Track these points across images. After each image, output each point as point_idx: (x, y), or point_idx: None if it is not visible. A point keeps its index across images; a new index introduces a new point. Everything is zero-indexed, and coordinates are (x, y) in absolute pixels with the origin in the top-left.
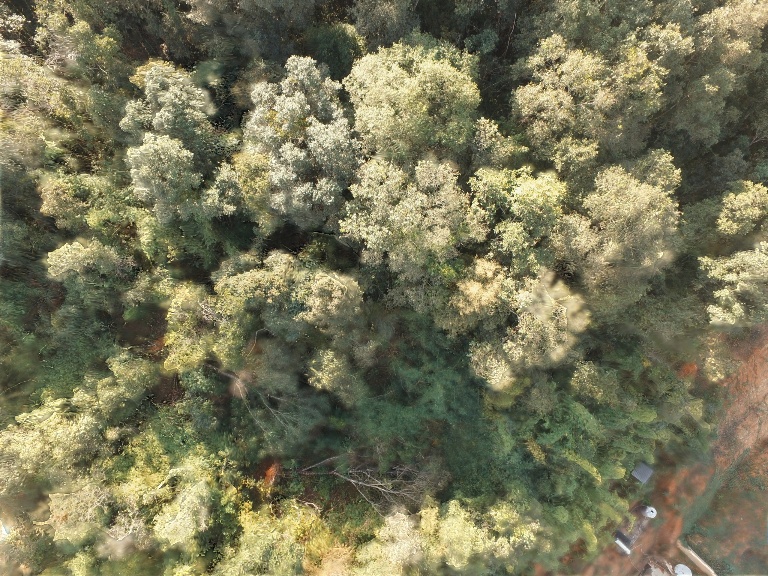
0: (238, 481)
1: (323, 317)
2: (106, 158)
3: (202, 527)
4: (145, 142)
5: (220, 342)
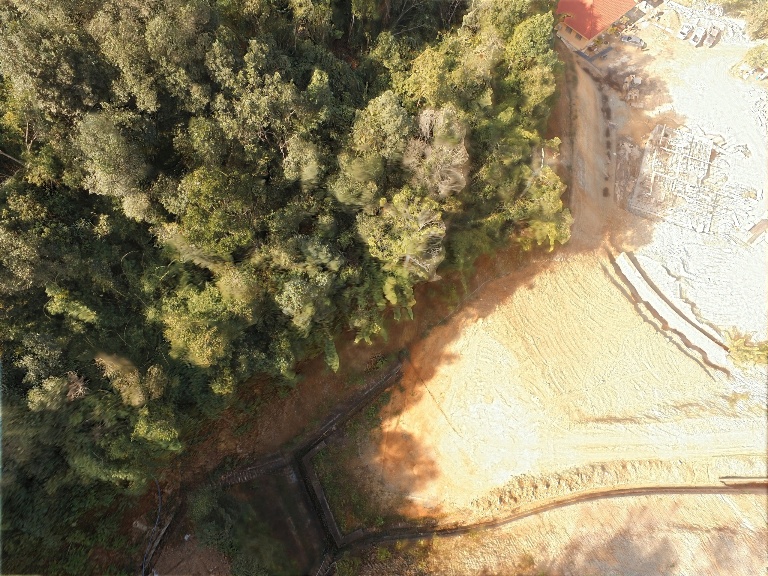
0: None
1: None
2: None
3: None
4: None
5: None
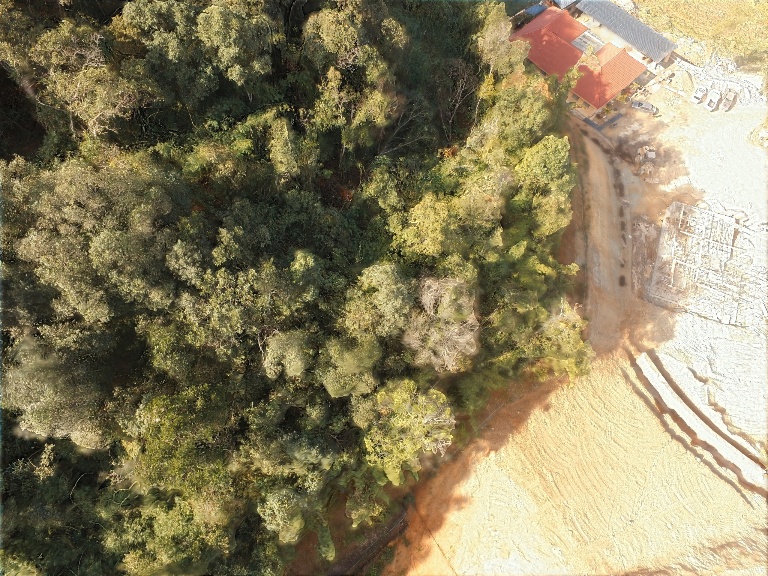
0: None
1: (363, 2)
2: (179, 133)
3: None
4: (209, 17)
5: (373, 64)
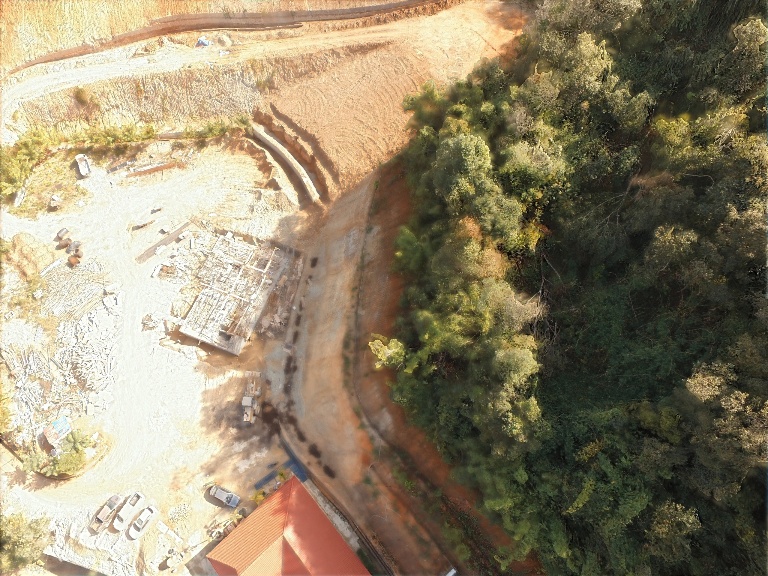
0: (541, 203)
1: (740, 224)
2: None
3: (512, 178)
4: None
5: (697, 149)
